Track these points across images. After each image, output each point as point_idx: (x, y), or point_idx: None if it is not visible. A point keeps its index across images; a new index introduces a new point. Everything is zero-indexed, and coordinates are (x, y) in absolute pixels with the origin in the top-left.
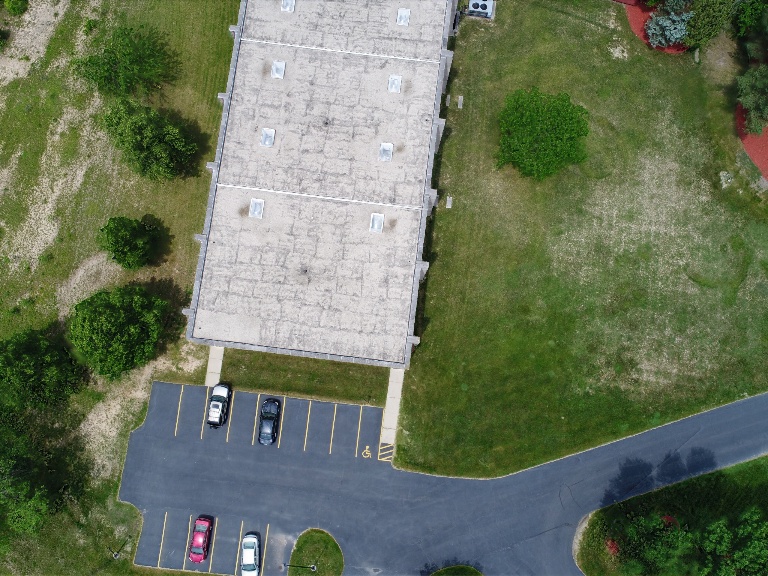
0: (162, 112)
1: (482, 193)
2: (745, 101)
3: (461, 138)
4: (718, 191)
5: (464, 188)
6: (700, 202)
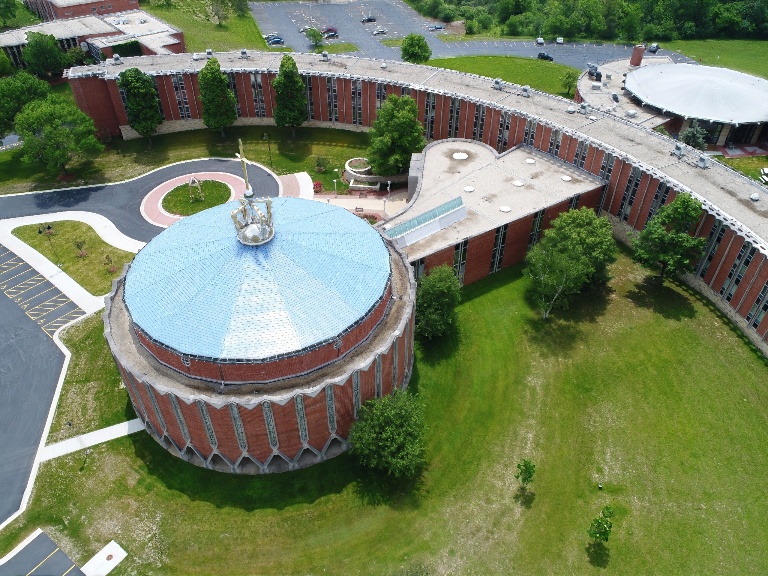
0: (148, 6)
1: None
2: None
3: None
4: None
5: None
6: None
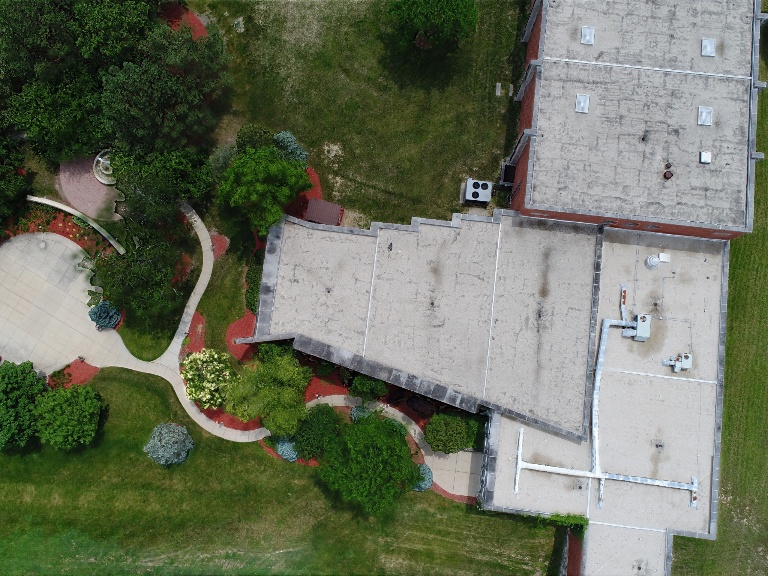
0: None
1: (476, 2)
2: (228, 56)
3: (497, 54)
4: (248, 14)
5: (494, 6)
6: (266, 3)
